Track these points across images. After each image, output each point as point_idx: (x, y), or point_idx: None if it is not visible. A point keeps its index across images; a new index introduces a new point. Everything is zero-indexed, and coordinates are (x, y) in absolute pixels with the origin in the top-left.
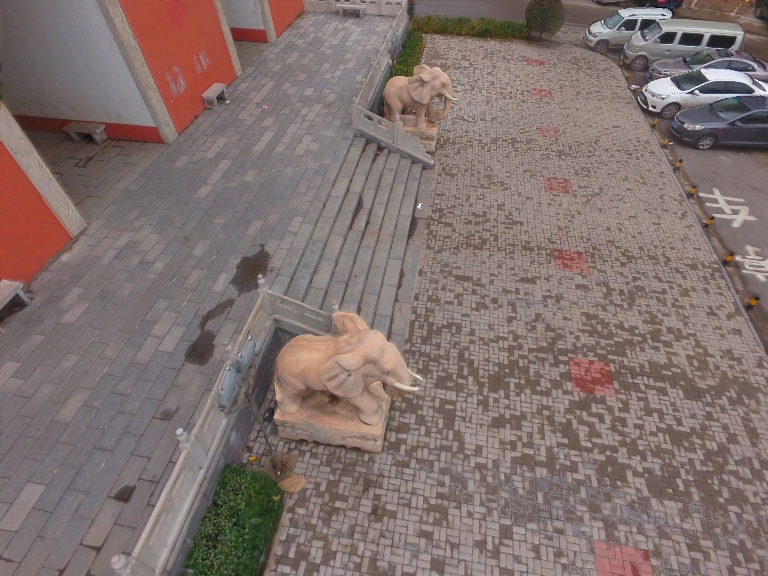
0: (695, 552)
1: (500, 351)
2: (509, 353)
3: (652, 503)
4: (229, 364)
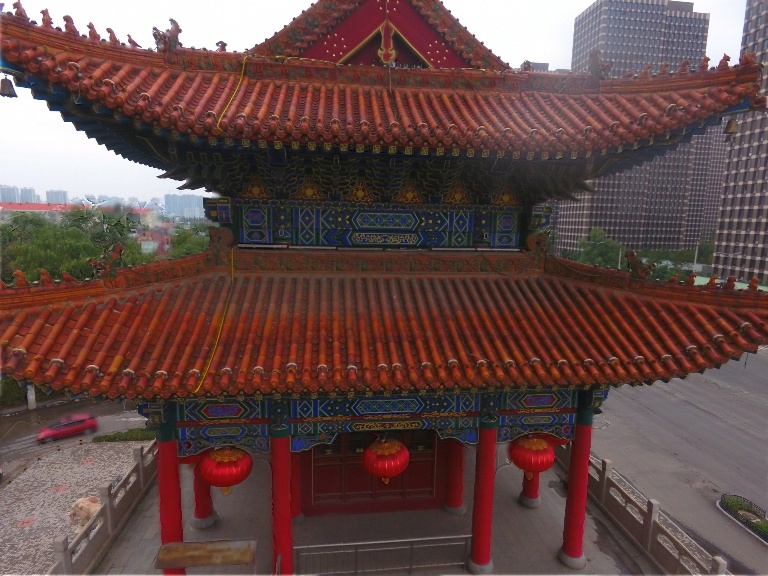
0: (0, 529)
1: (16, 568)
2: (12, 568)
3: (1, 536)
4: (117, 478)
